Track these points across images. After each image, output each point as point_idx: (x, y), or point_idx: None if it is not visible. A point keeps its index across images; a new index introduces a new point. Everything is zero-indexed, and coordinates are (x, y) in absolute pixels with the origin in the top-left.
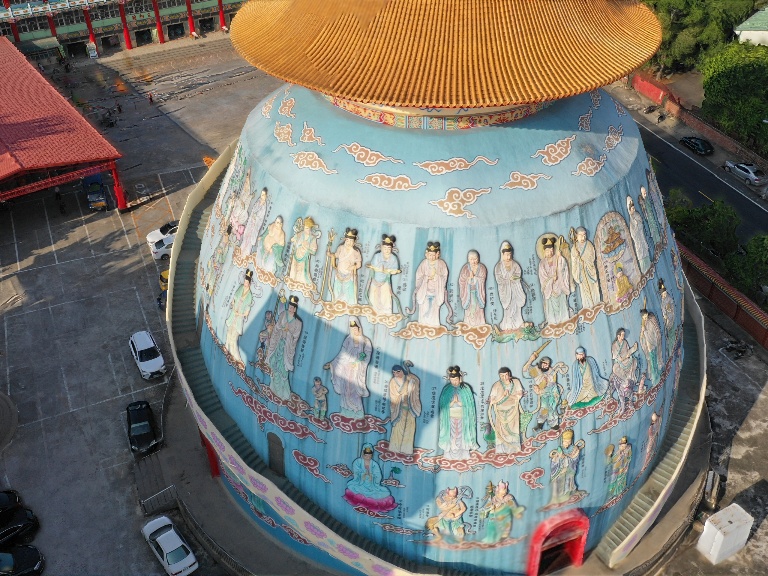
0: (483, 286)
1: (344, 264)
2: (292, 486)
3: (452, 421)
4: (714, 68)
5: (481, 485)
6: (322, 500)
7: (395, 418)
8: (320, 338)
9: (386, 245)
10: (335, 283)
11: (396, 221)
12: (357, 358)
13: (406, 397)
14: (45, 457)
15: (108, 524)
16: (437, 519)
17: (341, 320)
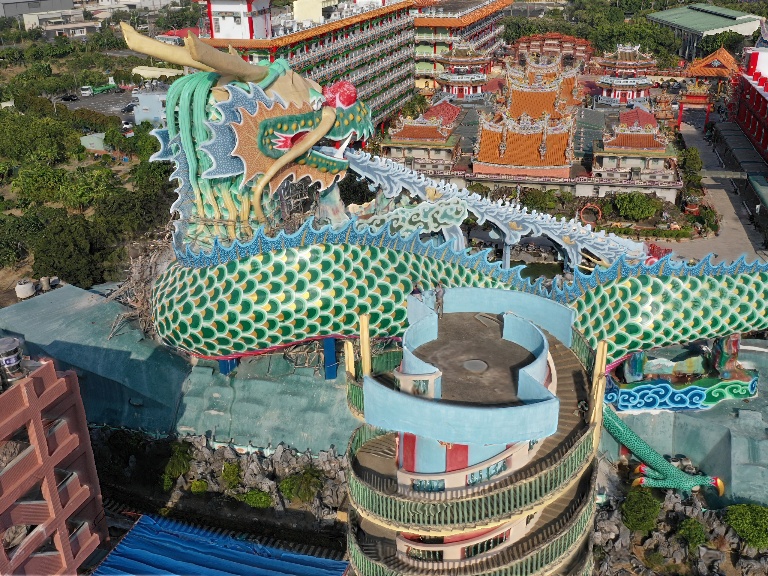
0: None
1: None
2: None
3: None
4: (720, 40)
5: None
6: None
7: None
8: None
9: None
10: None
11: None
12: None
13: None
14: None
15: None
16: None
17: None
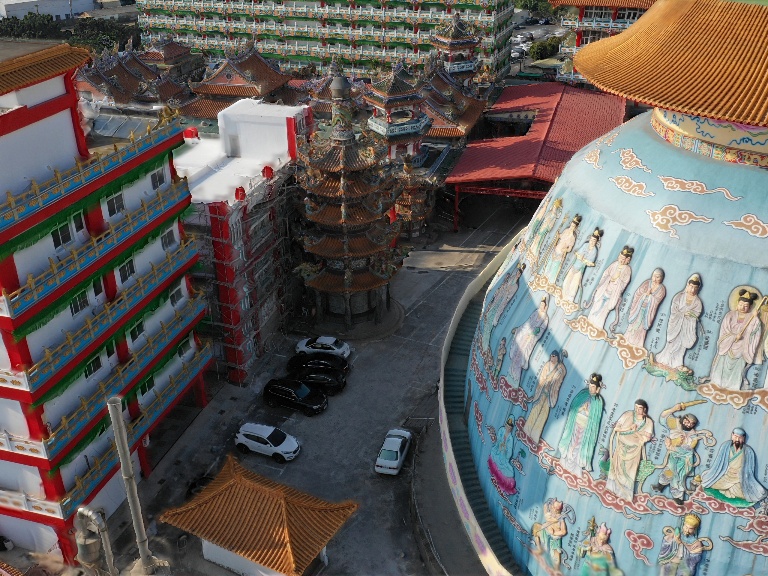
0: (655, 308)
1: (561, 245)
2: (467, 436)
3: (576, 427)
4: None
5: (585, 515)
6: (477, 459)
7: (536, 399)
8: (521, 304)
9: (593, 236)
10: (550, 260)
11: (611, 218)
12: (533, 331)
13: (550, 383)
14: (387, 359)
15: (378, 416)
16: (540, 527)
17: (539, 294)
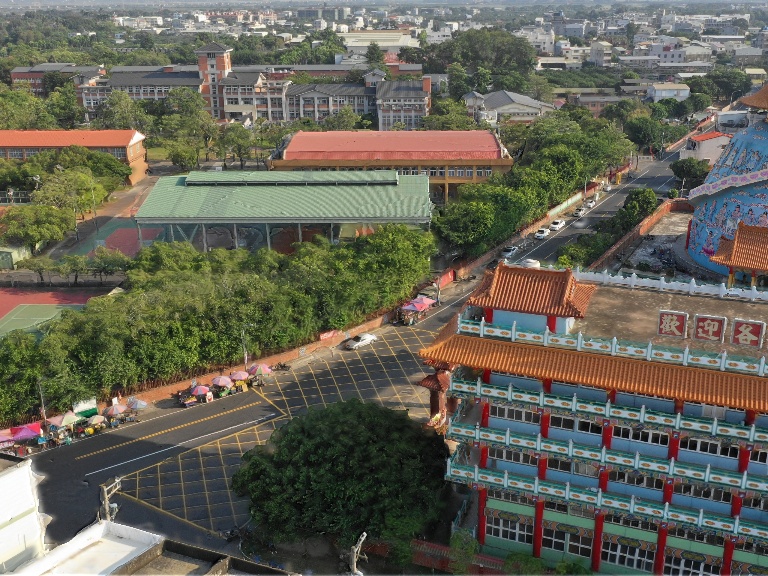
0: None
1: None
2: None
3: None
4: None
5: None
6: None
7: None
8: None
9: None
10: None
11: None
12: None
13: None
14: None
15: None
16: None
17: None
